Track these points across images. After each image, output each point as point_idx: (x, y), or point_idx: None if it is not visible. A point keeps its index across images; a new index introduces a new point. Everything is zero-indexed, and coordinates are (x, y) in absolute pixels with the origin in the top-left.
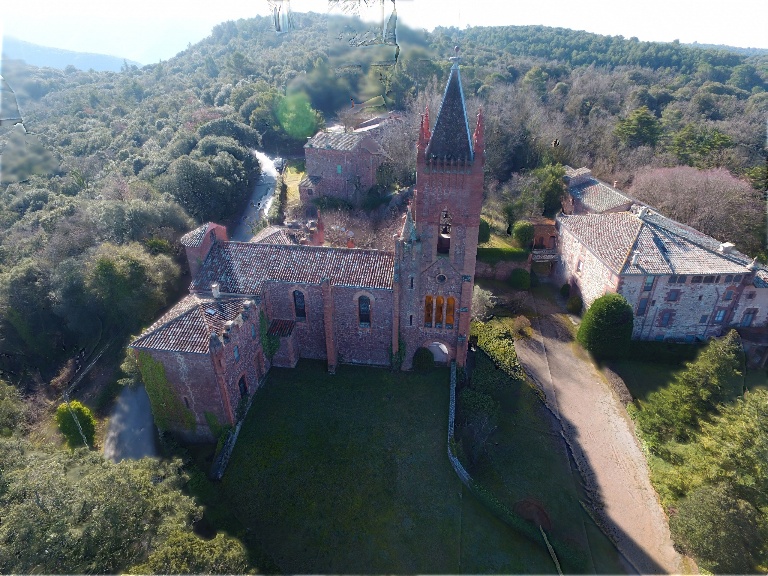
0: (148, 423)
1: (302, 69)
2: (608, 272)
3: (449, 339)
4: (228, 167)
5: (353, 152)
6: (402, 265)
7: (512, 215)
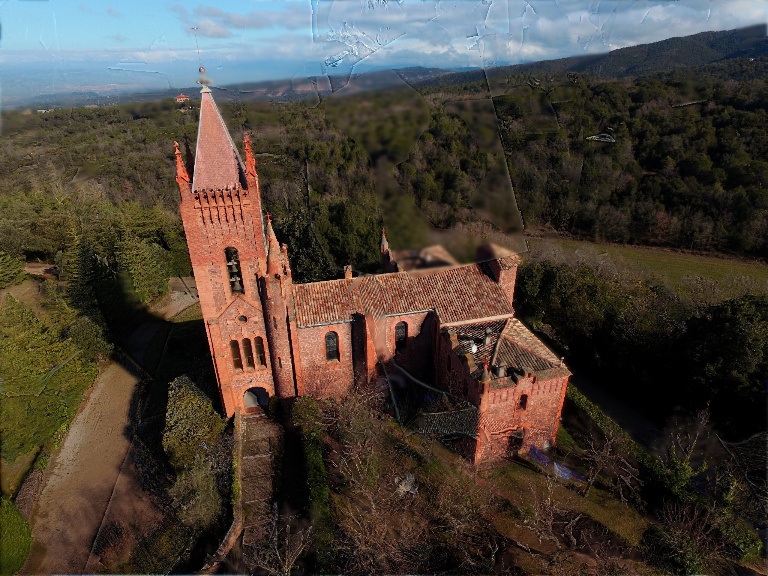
0: None
1: None
2: None
3: None
4: None
5: None
6: None
7: None
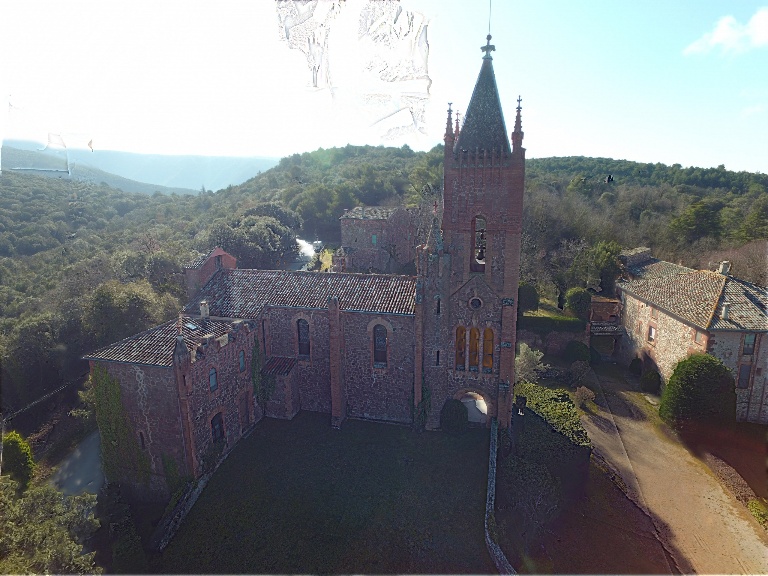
0: (100, 476)
1: (328, 92)
2: (691, 331)
3: (488, 388)
4: (264, 238)
5: (389, 222)
6: (426, 283)
7: (563, 284)
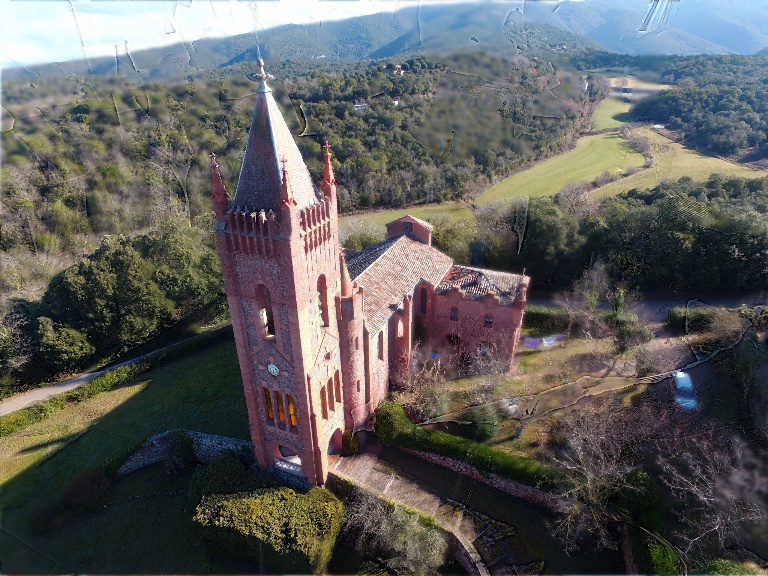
0: None
1: None
2: None
3: None
4: (751, 236)
5: None
6: None
7: None
